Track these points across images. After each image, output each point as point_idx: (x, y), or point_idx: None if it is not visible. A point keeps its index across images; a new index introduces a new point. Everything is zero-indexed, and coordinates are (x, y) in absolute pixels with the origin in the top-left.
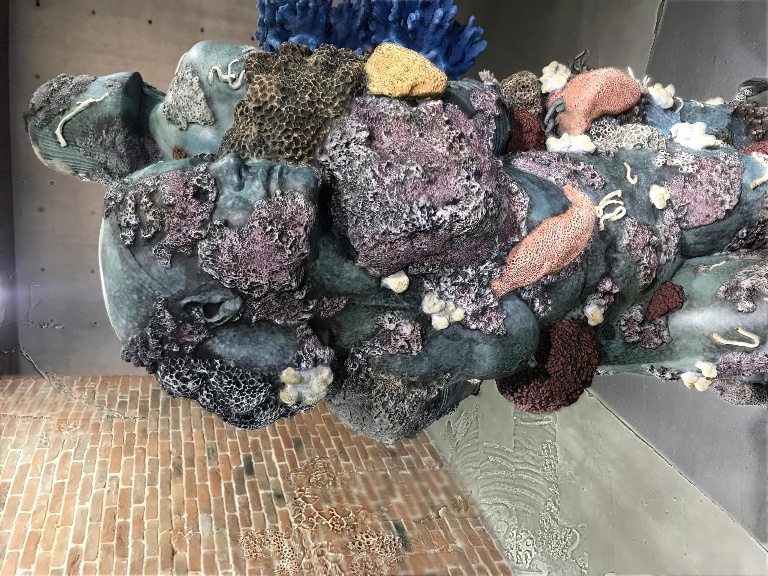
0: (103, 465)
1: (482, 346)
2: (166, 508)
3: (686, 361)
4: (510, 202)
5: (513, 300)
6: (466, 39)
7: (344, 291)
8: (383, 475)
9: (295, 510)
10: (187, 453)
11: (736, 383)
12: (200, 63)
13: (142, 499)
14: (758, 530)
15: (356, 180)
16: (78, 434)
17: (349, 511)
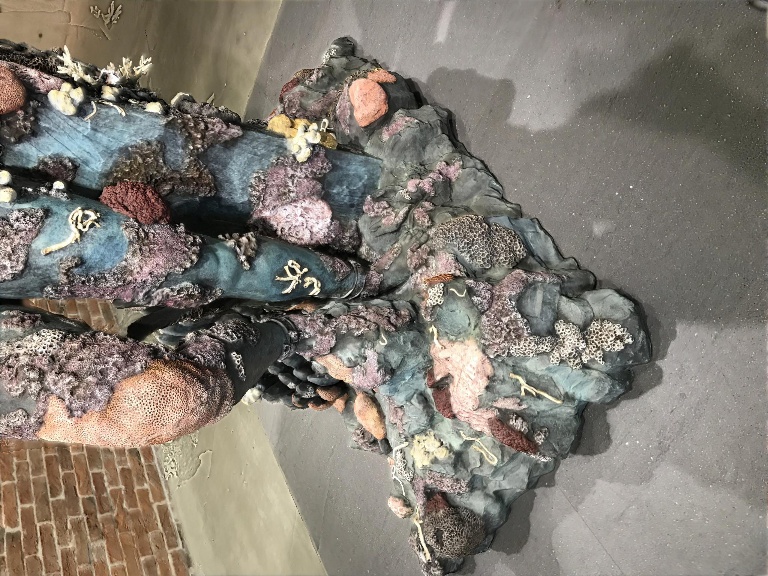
0: None
1: None
2: None
3: None
4: None
5: None
6: None
7: None
8: None
9: None
10: None
11: None
12: None
13: None
14: (277, 448)
15: None
16: None
17: None
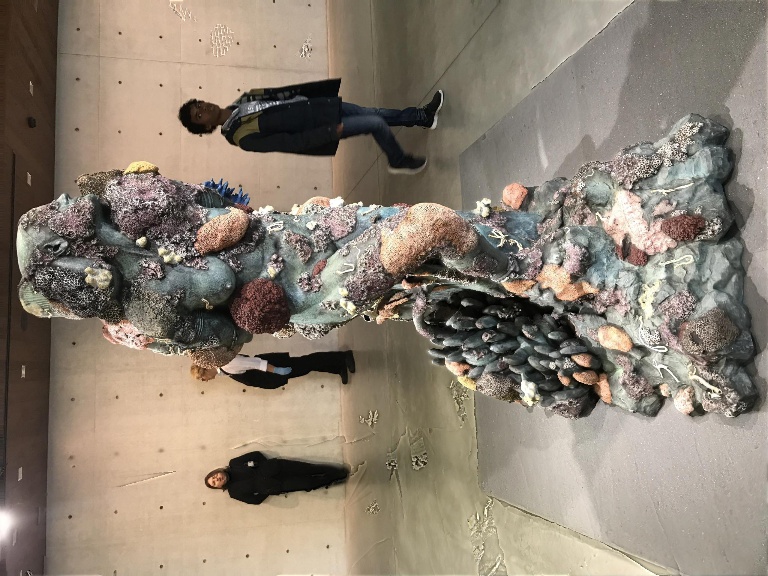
0: None
1: (197, 275)
2: None
3: (334, 292)
4: (195, 210)
5: (214, 258)
6: (239, 198)
7: (117, 244)
8: None
9: None
10: None
11: (483, 376)
12: None
13: None
14: (602, 533)
15: None
16: None
17: None
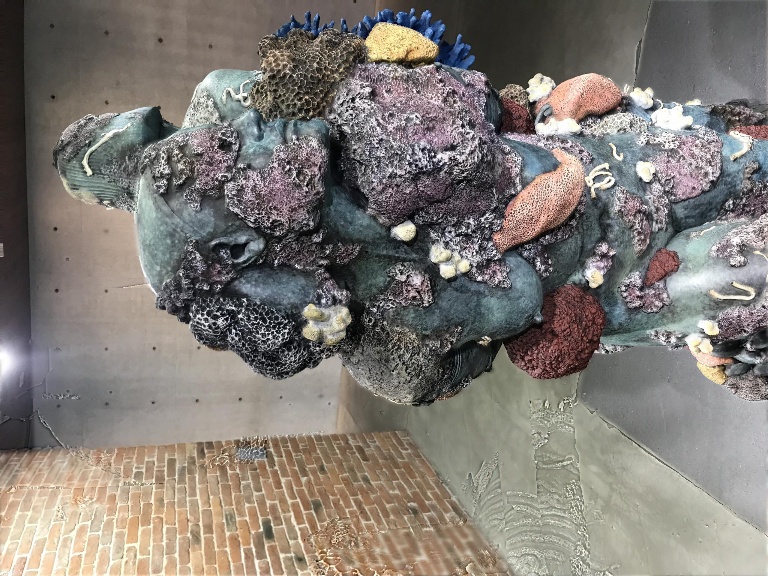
0: (120, 536)
1: (489, 299)
2: (185, 575)
3: (688, 322)
4: (504, 159)
5: (515, 257)
6: (455, 55)
7: (357, 238)
8: (406, 533)
9: (318, 572)
10: (205, 520)
11: (748, 377)
12: (214, 87)
13: (160, 568)
14: None
15: (362, 130)
16: (94, 506)
17: (373, 571)
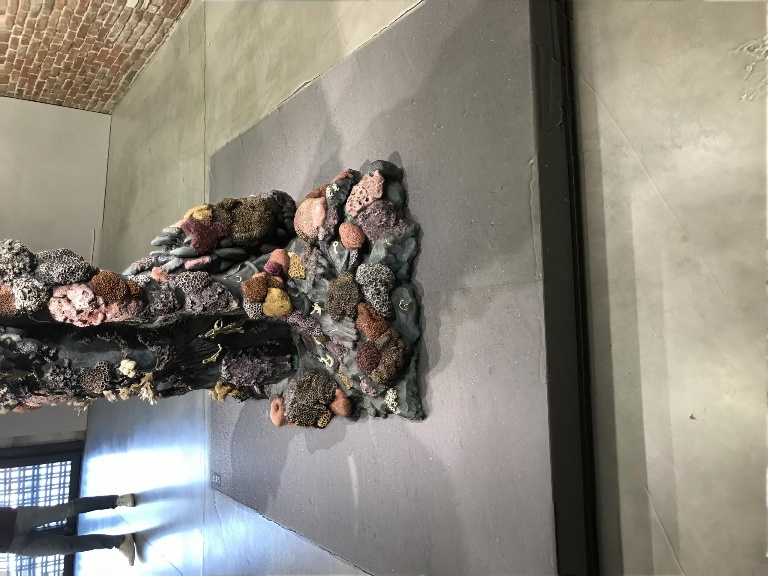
0: None
1: None
2: None
3: None
4: None
5: None
6: None
7: None
8: None
9: None
10: None
11: None
12: None
13: None
14: None
15: None
16: None
17: None
